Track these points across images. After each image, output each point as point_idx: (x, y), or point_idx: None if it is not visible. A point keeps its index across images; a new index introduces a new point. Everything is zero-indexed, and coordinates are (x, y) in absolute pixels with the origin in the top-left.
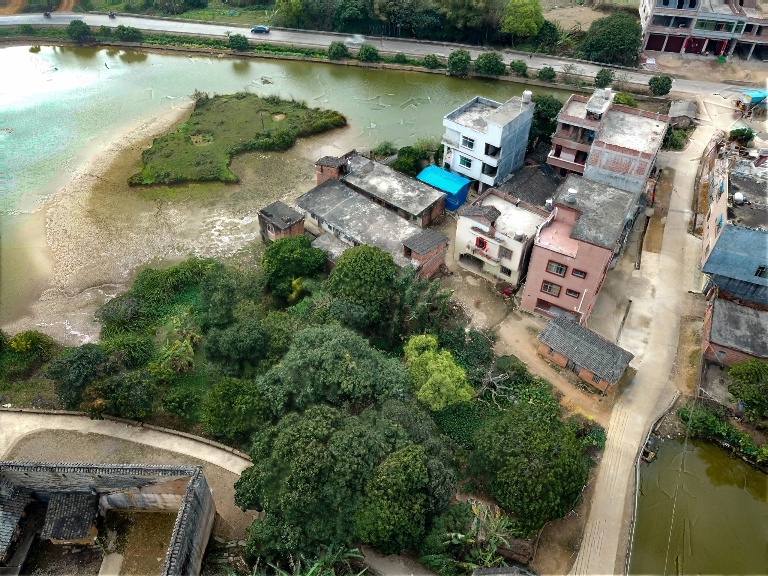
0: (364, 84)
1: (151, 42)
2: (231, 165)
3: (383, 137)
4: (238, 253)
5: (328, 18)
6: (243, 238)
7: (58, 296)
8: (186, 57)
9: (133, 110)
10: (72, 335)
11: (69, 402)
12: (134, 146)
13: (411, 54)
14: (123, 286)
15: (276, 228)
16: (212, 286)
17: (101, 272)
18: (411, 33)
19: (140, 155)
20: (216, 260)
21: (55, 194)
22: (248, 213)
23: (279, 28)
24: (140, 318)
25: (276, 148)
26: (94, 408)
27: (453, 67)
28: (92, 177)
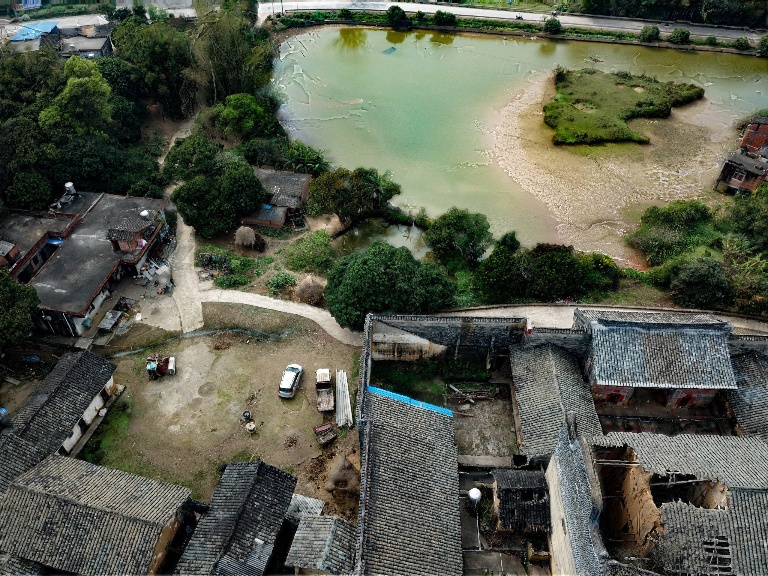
0: (674, 64)
1: (465, 26)
2: (629, 128)
3: (760, 105)
4: (701, 198)
5: (626, 5)
6: (694, 187)
7: (573, 230)
8: (500, 39)
9: (500, 83)
10: (614, 259)
11: (703, 302)
12: (526, 112)
13: (721, 37)
14: (623, 223)
15: (751, 175)
16: (748, 217)
17: (593, 212)
18: (703, 19)
19: (539, 120)
20: (700, 202)
21: (492, 150)
22: (679, 167)
23: (577, 14)
24: (674, 246)
25: (661, 115)
26: (756, 302)
27: (767, 48)
28: (512, 137)
